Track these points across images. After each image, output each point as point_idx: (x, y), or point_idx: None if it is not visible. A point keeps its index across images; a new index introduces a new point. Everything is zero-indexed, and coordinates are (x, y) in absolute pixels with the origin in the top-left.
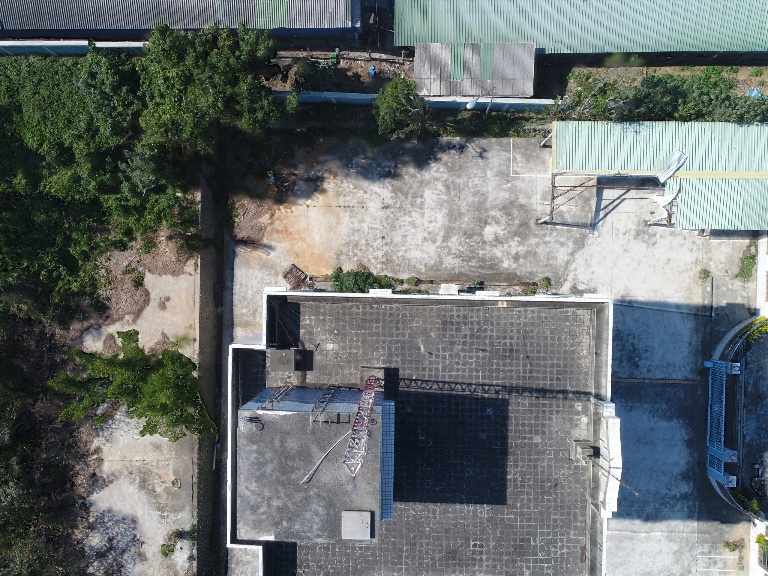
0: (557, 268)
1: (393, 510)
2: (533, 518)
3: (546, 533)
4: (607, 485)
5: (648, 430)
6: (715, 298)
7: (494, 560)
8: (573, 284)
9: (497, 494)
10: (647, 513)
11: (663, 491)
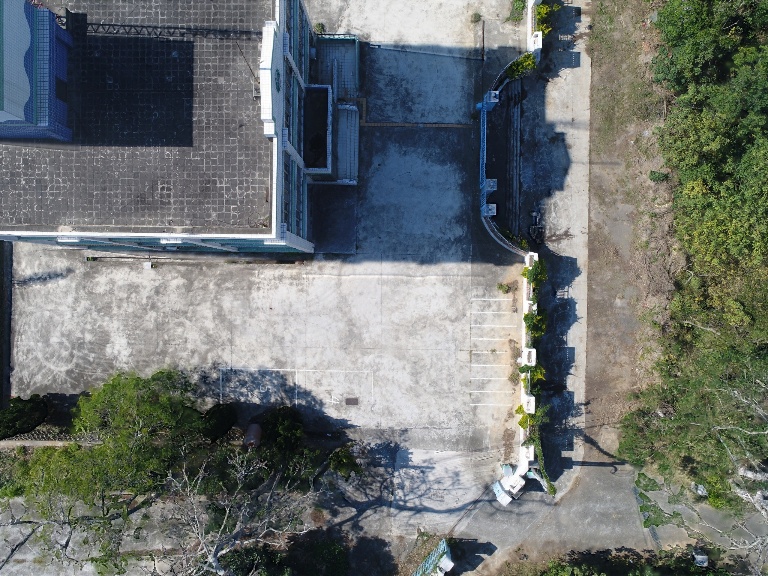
0: (331, 14)
1: (83, 155)
2: (219, 160)
3: (232, 174)
4: (260, 91)
5: (422, 174)
6: (487, 42)
7: (182, 203)
8: (347, 30)
9: (183, 136)
10: (422, 257)
11: (437, 235)
